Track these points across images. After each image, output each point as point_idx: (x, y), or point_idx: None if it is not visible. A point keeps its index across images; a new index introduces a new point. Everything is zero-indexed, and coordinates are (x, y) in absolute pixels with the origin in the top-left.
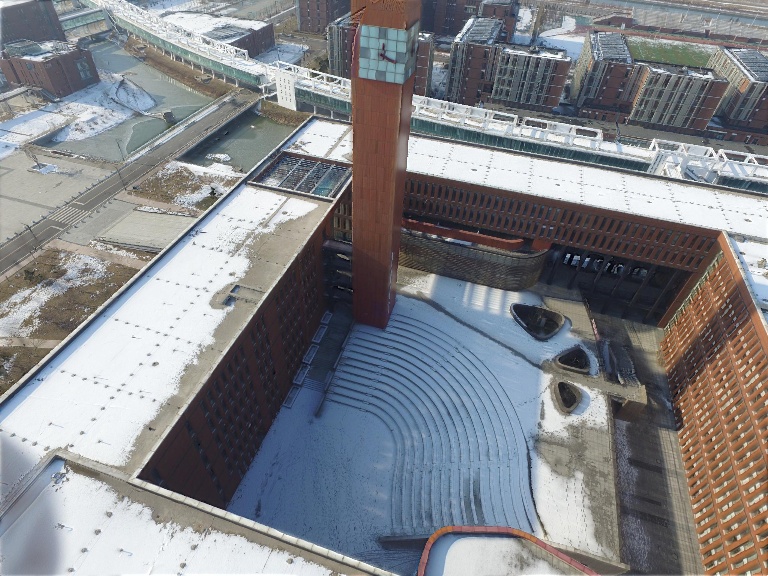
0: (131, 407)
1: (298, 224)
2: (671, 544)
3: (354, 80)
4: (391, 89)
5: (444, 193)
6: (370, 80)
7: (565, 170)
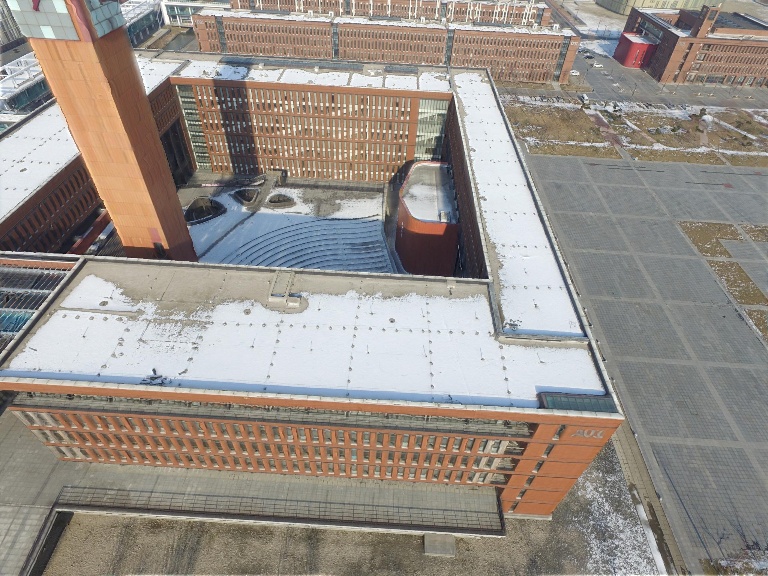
0: (440, 315)
1: (136, 284)
2: (358, 188)
3: (98, 44)
4: (122, 35)
5: (56, 200)
6: (107, 35)
7: (45, 122)
